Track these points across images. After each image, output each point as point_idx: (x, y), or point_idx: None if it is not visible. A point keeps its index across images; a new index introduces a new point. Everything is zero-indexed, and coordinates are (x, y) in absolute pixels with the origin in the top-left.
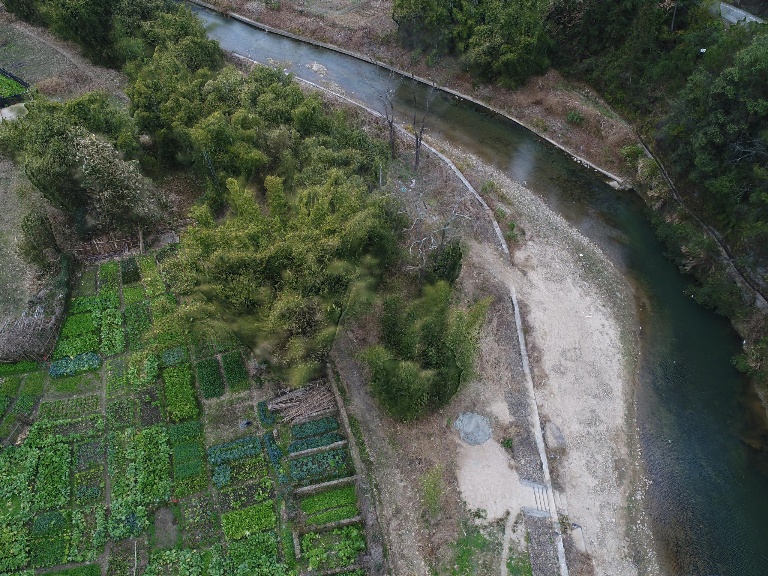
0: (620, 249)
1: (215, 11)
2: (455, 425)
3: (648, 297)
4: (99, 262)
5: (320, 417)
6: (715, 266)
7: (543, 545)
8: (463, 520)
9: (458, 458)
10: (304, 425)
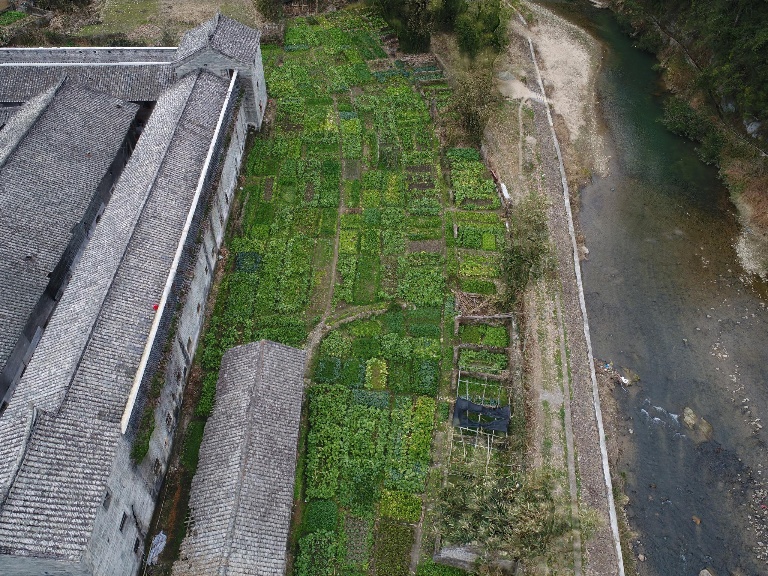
0: (596, 31)
1: None
2: (496, 75)
3: (609, 48)
4: (294, 17)
5: (427, 65)
6: (650, 31)
7: (540, 109)
8: (501, 98)
9: (498, 83)
10: (419, 68)
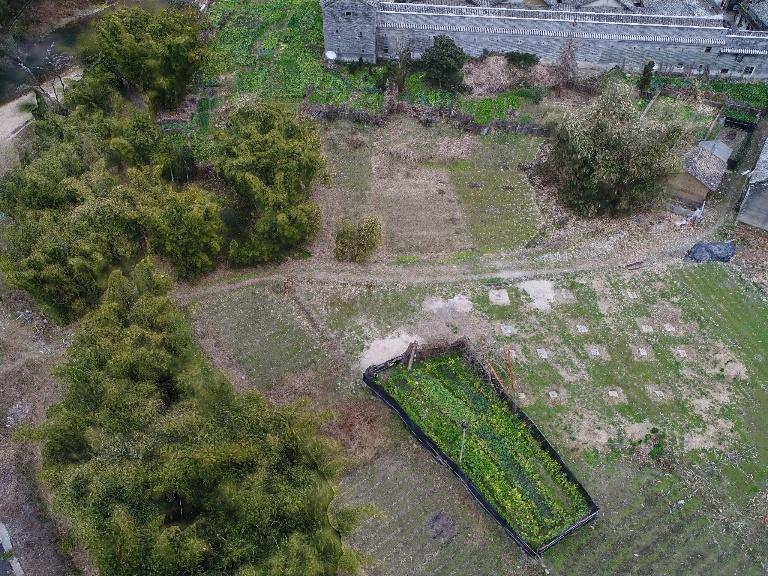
0: None
1: None
2: None
3: None
4: None
5: None
6: None
7: None
8: None
9: None
10: None
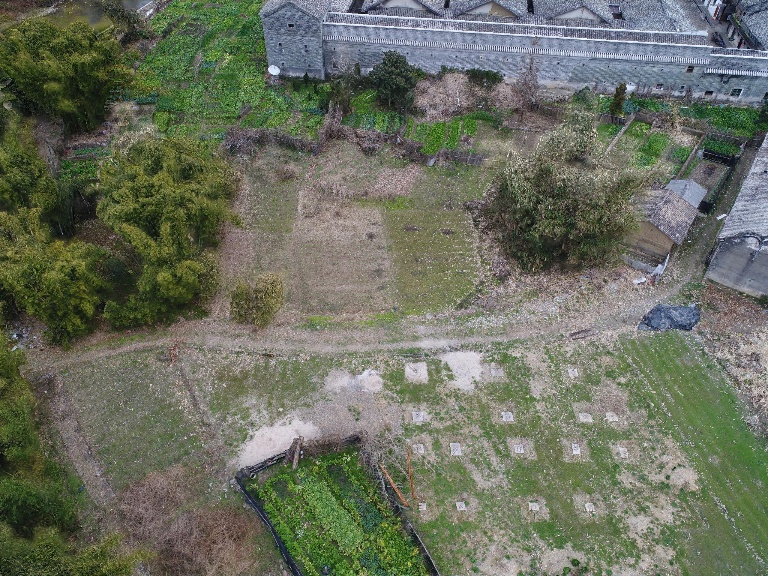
0: None
1: None
2: None
3: None
4: None
5: None
6: None
7: None
8: None
9: None
10: None
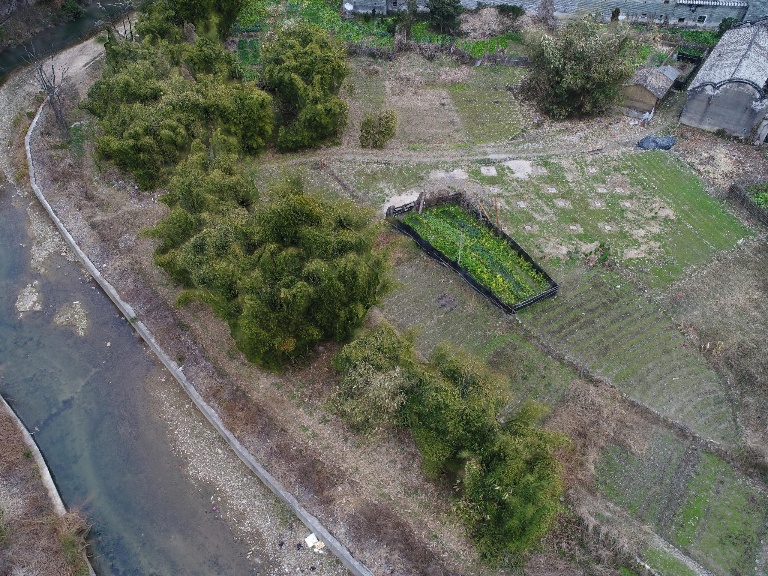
0: None
1: (93, 565)
2: None
3: None
4: None
5: None
6: None
7: None
8: None
9: None
10: None
